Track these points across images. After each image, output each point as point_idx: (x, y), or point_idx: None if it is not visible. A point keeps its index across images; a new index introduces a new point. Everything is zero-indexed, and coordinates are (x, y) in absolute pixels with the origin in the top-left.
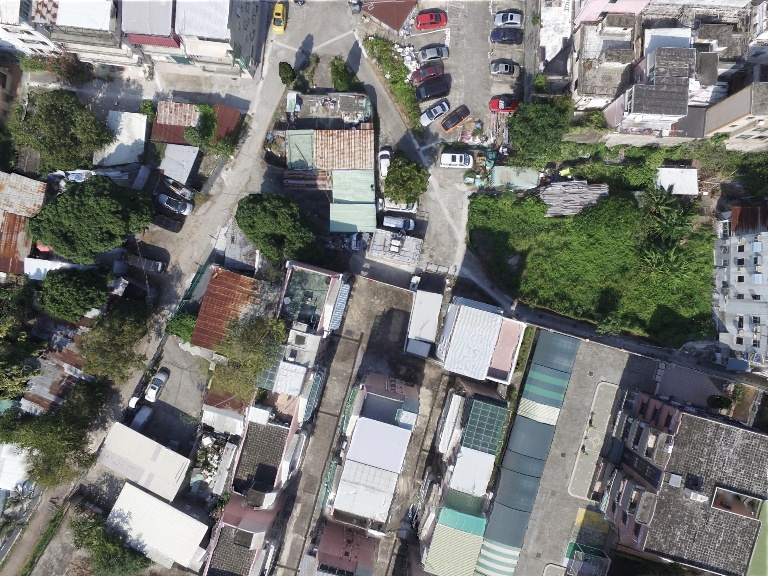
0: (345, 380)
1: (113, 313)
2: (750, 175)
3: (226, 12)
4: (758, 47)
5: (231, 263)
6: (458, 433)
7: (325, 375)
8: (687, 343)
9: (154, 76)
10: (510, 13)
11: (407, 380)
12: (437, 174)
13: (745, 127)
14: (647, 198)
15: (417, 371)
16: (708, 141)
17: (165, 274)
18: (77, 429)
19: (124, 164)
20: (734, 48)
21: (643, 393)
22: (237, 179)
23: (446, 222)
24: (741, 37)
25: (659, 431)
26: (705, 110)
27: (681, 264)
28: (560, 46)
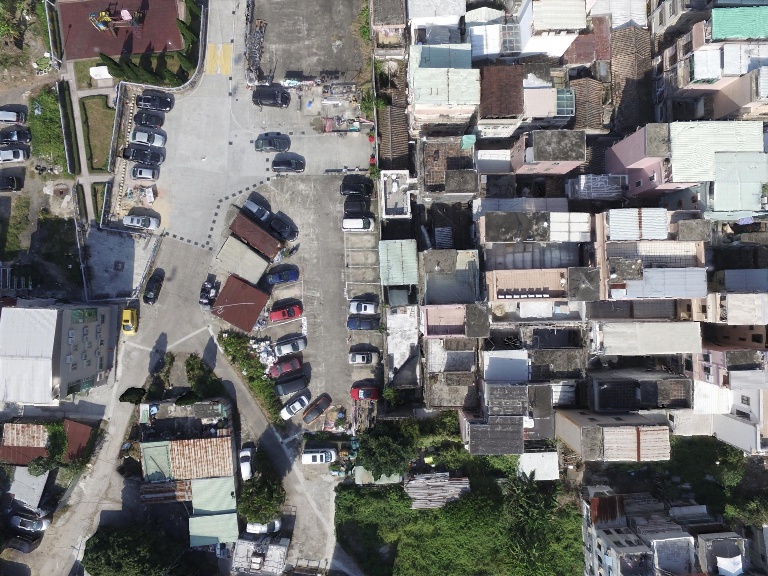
0: None
1: None
2: None
3: (49, 378)
4: None
5: None
6: None
7: None
8: None
9: None
10: (363, 304)
11: None
12: (302, 467)
13: None
14: (510, 486)
15: None
16: None
17: None
18: None
19: None
20: (573, 361)
21: None
22: (96, 486)
23: (314, 515)
24: (579, 351)
25: None
26: (554, 412)
27: None
28: (408, 353)
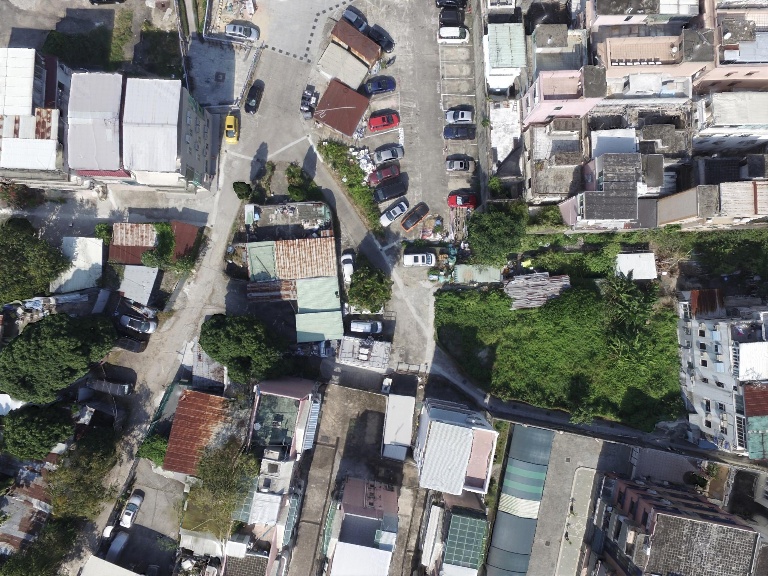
0: (324, 487)
1: (79, 450)
2: (705, 254)
3: (174, 145)
4: (701, 138)
5: (199, 381)
6: (439, 547)
7: (303, 486)
8: (659, 423)
9: (108, 195)
10: (461, 111)
11: (386, 482)
12: (401, 273)
13: (695, 222)
14: (608, 285)
15: (396, 472)
16: (662, 230)
17: (133, 394)
18: (50, 565)
19: (82, 289)
20: (678, 143)
21: (620, 479)
22: (200, 292)
23: (414, 320)
24: (684, 133)
25: (637, 528)
26: (656, 201)
27: (646, 352)
28: (511, 146)
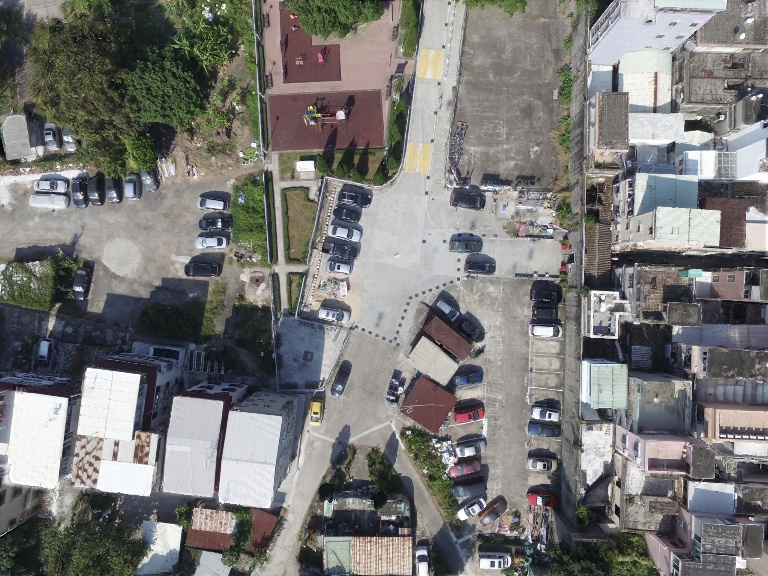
0: None
1: None
2: None
3: (271, 484)
4: None
5: None
6: None
7: None
8: None
9: None
10: (548, 411)
11: None
12: (474, 568)
13: None
14: None
15: None
16: None
17: None
18: None
19: None
20: None
21: None
22: (272, 572)
23: None
24: None
25: None
26: None
27: None
28: (601, 470)
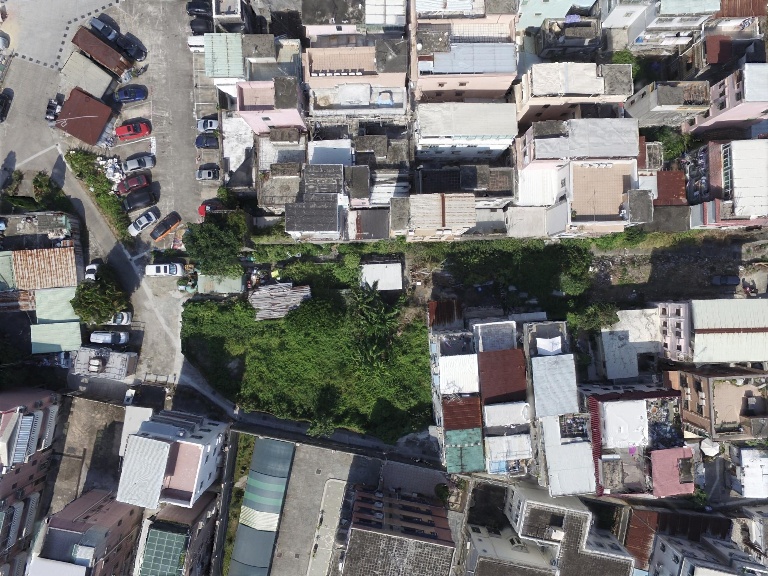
0: (70, 498)
1: None
2: (457, 264)
3: None
4: (431, 148)
5: None
6: None
7: None
8: (409, 434)
9: None
10: (209, 120)
11: None
12: (150, 283)
13: None
14: None
15: None
16: (396, 241)
17: None
18: None
19: None
20: (400, 154)
21: (360, 491)
22: None
23: (162, 331)
24: (404, 143)
25: None
26: (388, 211)
27: (378, 364)
28: (244, 156)
